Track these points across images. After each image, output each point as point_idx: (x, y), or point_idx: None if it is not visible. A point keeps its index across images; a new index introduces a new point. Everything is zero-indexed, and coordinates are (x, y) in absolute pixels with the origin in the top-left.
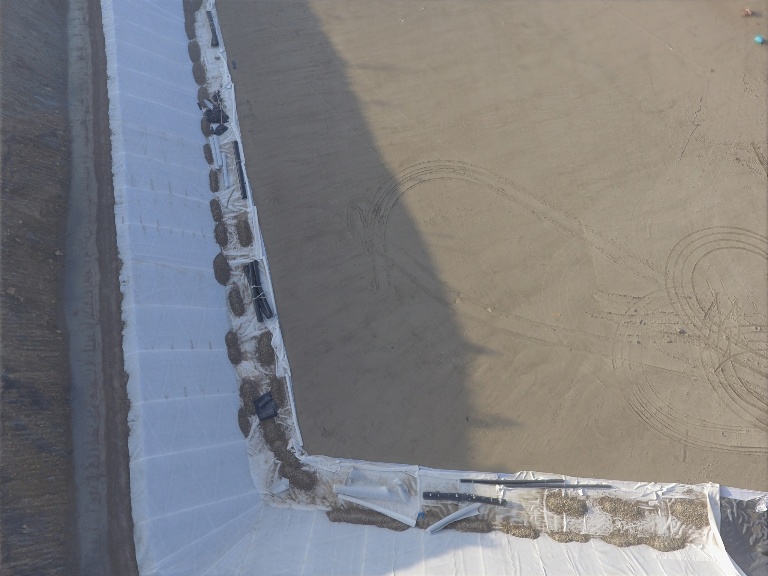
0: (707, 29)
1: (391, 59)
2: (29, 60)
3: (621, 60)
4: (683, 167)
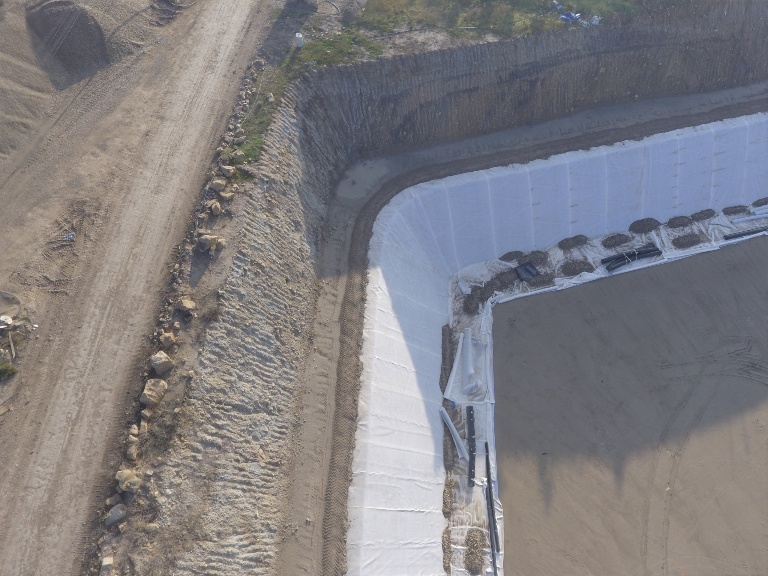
0: None
1: None
2: None
3: None
4: None
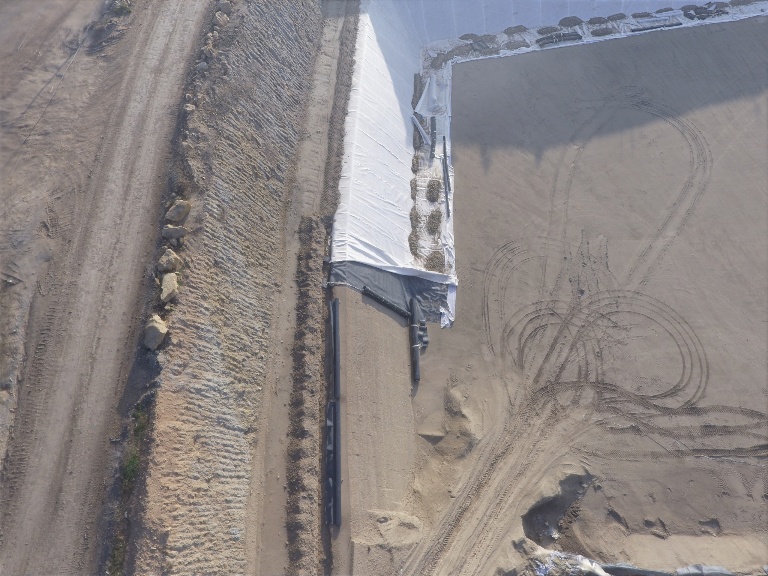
0: None
1: None
2: None
3: None
4: None
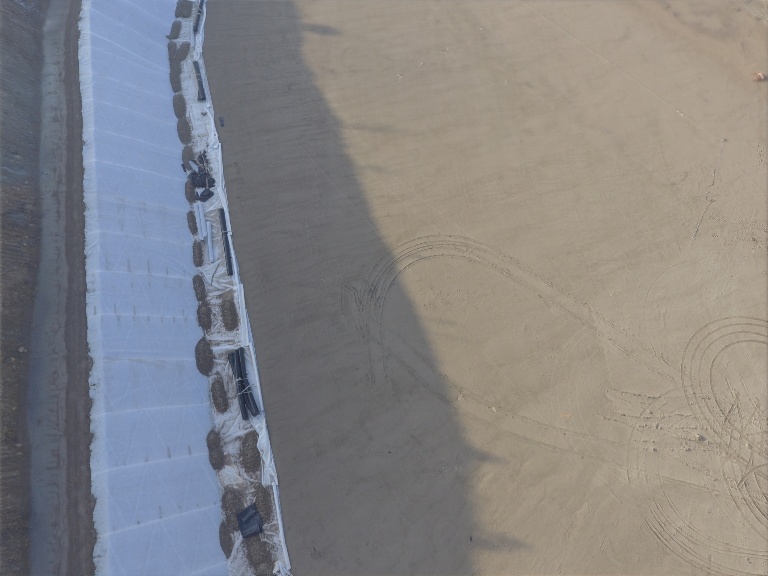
0: (718, 94)
1: (388, 119)
2: None
3: (630, 126)
4: (697, 248)
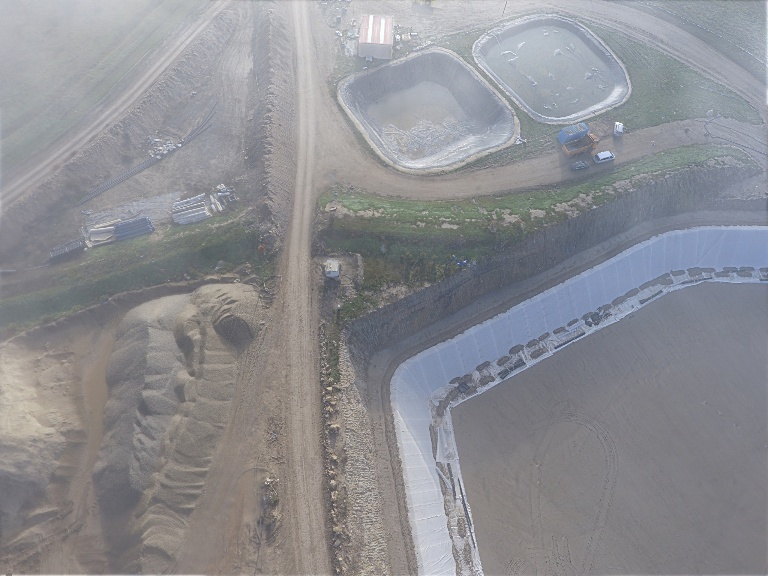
0: None
1: (672, 402)
2: (585, 236)
3: (732, 549)
4: None
